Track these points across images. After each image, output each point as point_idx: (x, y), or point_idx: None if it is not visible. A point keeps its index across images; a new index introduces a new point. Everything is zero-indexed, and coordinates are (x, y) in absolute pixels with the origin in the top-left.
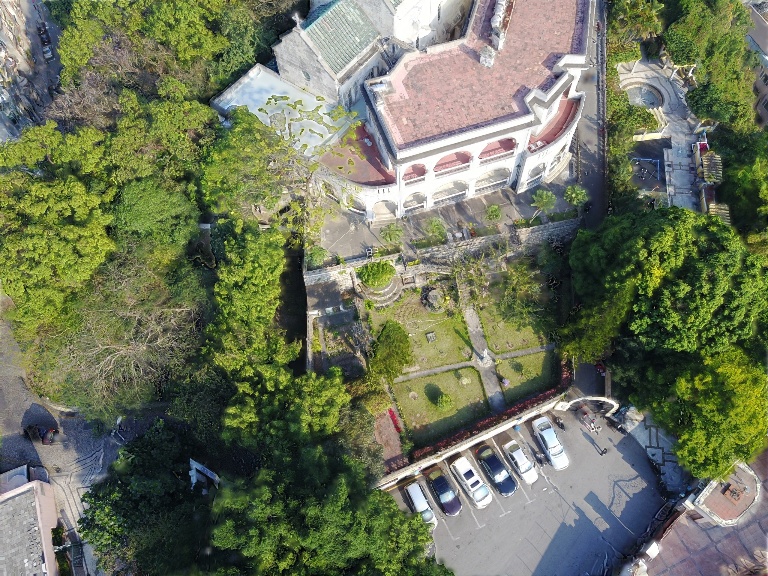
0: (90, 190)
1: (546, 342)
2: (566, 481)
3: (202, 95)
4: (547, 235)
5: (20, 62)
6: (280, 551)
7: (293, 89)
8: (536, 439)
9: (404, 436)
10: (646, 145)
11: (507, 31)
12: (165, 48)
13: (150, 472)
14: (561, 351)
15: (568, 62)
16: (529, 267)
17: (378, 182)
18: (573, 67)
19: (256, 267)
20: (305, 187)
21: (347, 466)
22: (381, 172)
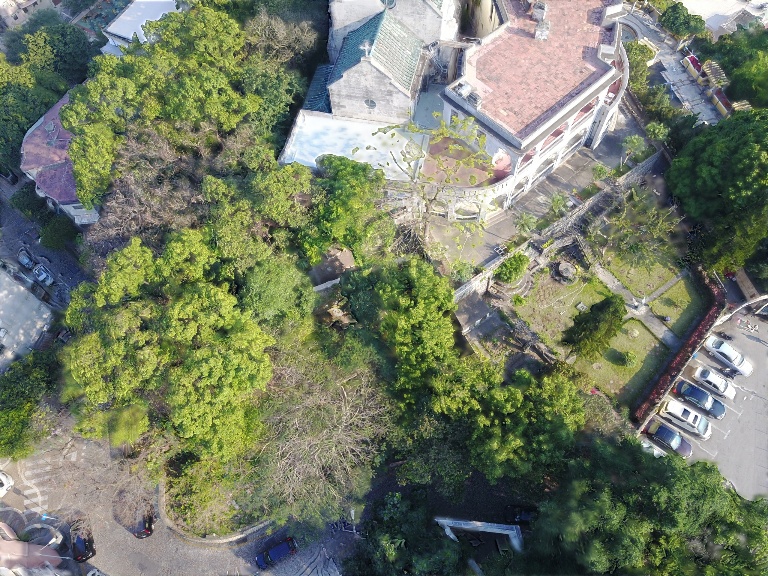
0: None
1: (678, 271)
2: (757, 383)
3: None
4: (635, 177)
5: None
6: (650, 549)
7: (349, 123)
8: (715, 358)
9: (615, 405)
10: None
11: None
12: (207, 124)
13: (419, 549)
14: (709, 271)
15: (608, 14)
16: (629, 211)
17: (490, 180)
18: (614, 17)
19: (432, 302)
20: (404, 213)
21: (635, 447)
22: (486, 170)
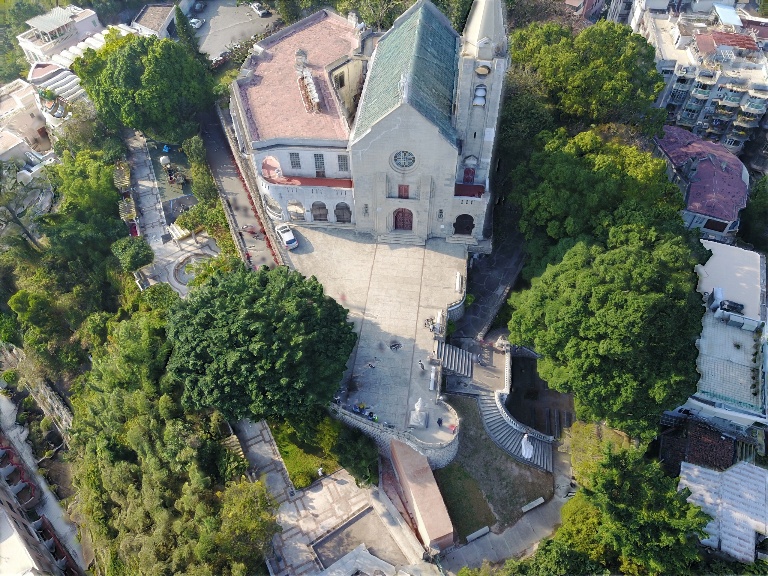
0: None
1: None
2: None
3: None
4: None
5: None
6: None
7: None
8: None
9: None
10: None
11: None
12: None
13: None
14: None
15: None
16: None
17: None
18: None
19: None
20: None
21: None
22: None
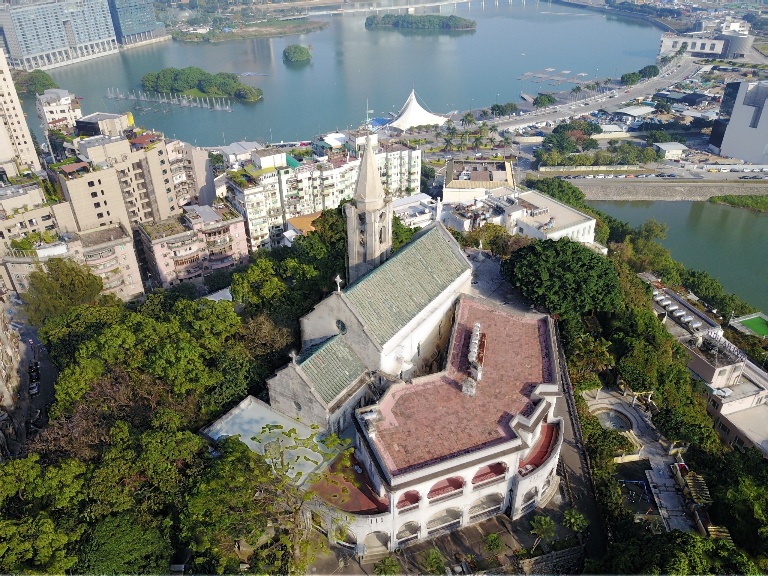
0: (56, 528)
1: None
2: None
3: (192, 426)
4: (551, 566)
5: (5, 398)
6: None
7: (283, 419)
8: None
9: None
10: (627, 467)
11: (483, 365)
12: (162, 383)
13: None
14: None
15: (543, 390)
16: None
17: (370, 511)
18: (548, 395)
19: None
20: (291, 519)
21: None
22: (373, 500)
